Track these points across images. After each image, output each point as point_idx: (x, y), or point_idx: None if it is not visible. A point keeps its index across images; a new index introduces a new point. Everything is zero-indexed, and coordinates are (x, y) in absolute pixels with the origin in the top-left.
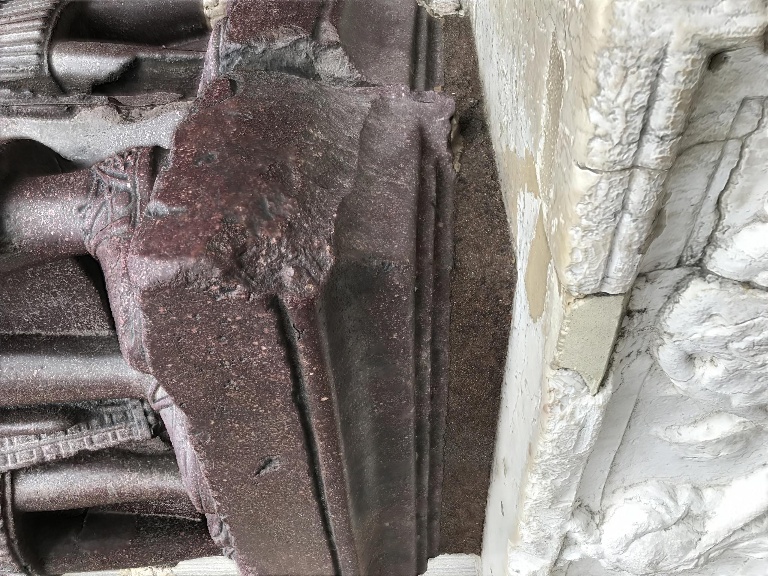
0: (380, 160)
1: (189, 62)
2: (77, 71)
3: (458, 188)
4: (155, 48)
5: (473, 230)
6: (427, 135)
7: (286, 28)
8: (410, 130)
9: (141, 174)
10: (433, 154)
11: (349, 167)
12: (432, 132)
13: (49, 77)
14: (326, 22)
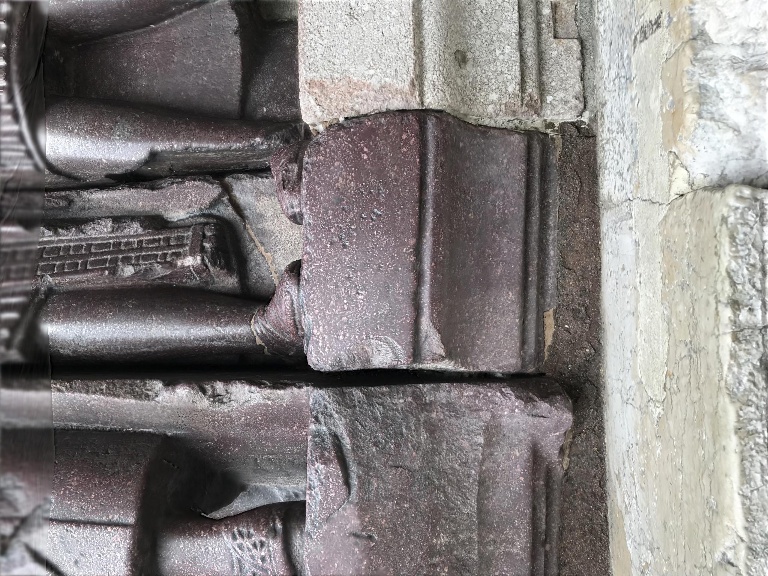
0: (496, 521)
1: (218, 150)
2: (80, 165)
3: (565, 491)
4: (168, 129)
5: (577, 555)
6: (539, 447)
7: (380, 342)
8: (523, 459)
9: (280, 573)
10: (543, 462)
11: (470, 559)
12: (545, 445)
13: (49, 173)
14: (426, 322)
